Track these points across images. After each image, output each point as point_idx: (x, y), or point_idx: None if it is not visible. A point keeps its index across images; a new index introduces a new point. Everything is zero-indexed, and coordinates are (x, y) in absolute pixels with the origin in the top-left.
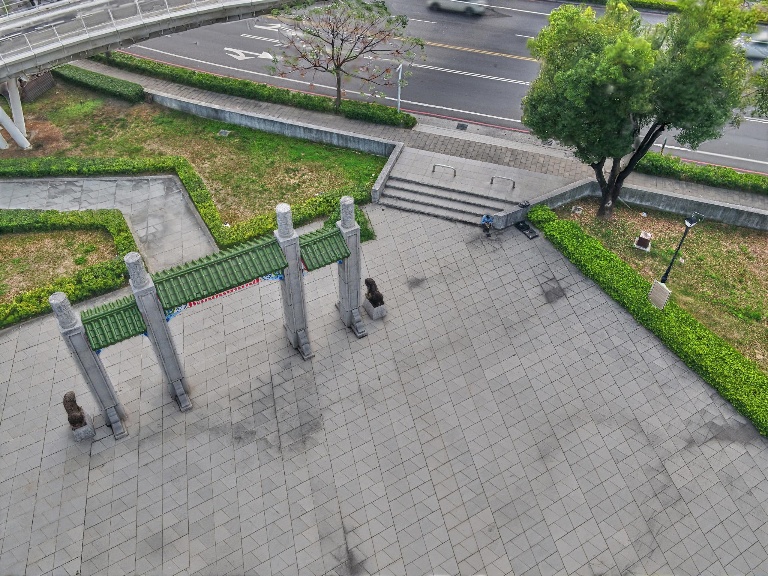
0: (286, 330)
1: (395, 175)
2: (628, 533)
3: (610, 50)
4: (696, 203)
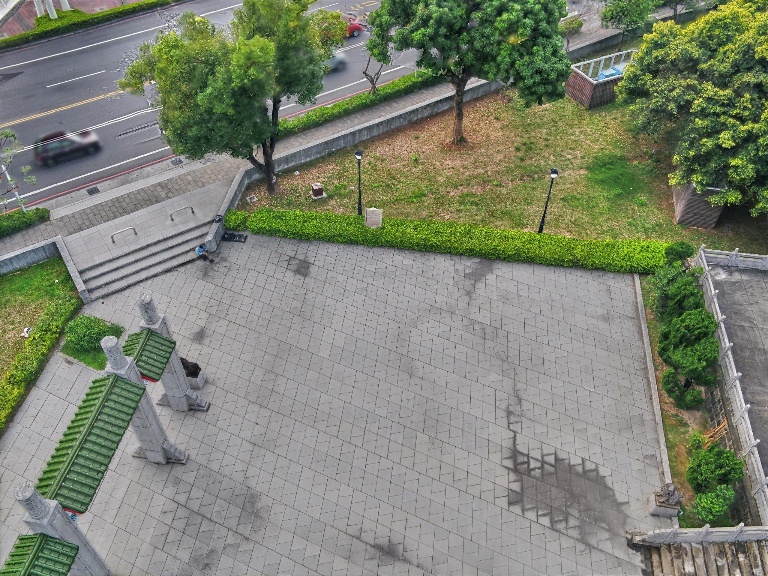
0: (140, 458)
1: (83, 267)
2: (495, 372)
3: (238, 58)
4: (324, 143)
